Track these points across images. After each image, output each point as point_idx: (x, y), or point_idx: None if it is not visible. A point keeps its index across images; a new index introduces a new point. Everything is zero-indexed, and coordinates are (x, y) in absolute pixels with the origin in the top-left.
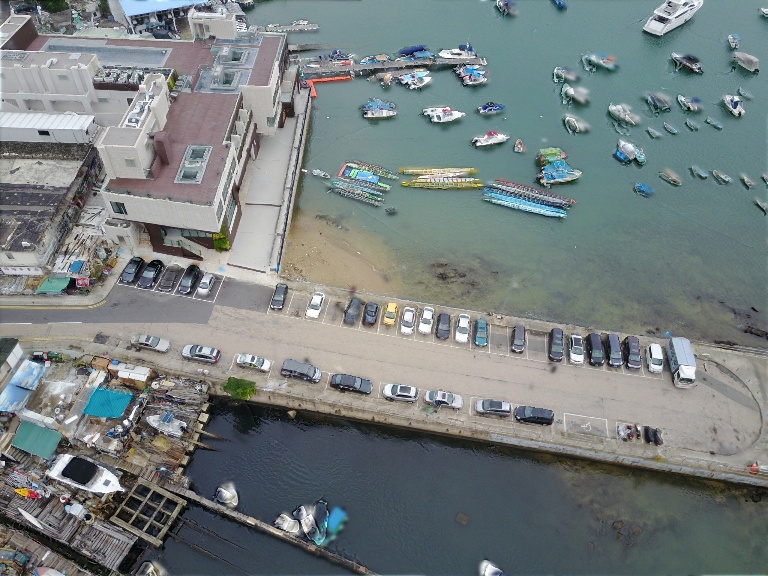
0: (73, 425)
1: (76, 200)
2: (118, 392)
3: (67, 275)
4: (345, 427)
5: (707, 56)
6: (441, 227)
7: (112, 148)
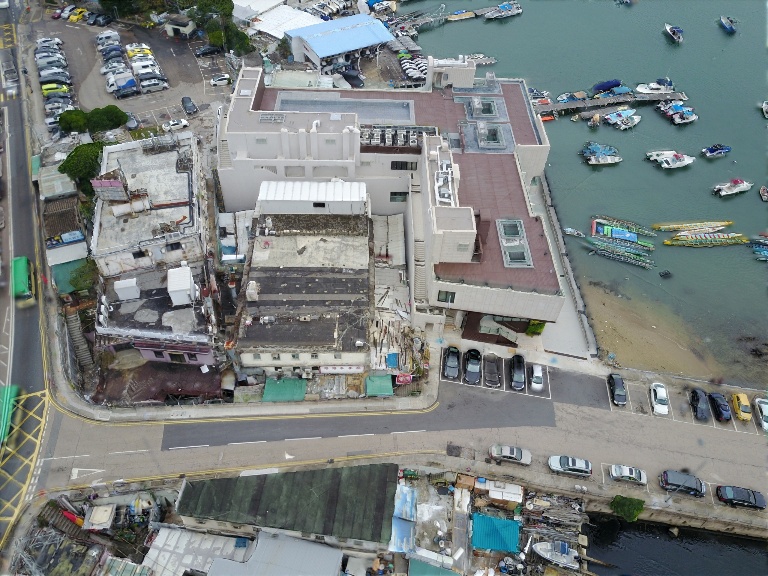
0: (462, 560)
1: None
2: (494, 516)
3: (388, 372)
4: (734, 545)
5: None
6: (726, 293)
7: (450, 233)
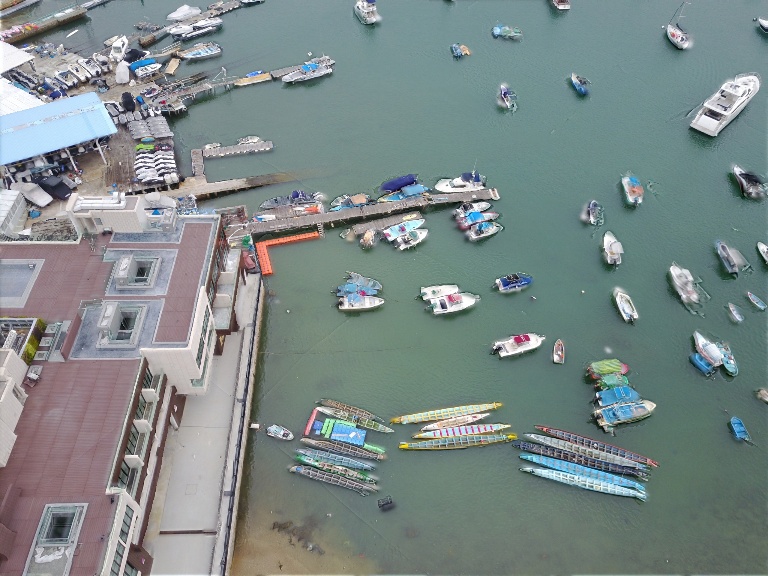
0: None
1: None
2: None
3: None
4: None
5: None
6: (463, 533)
7: None
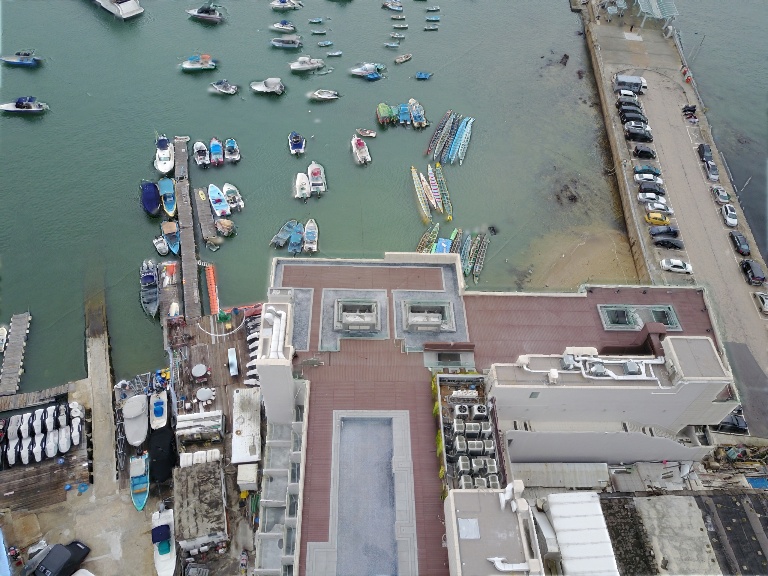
0: None
1: None
2: None
3: None
4: None
5: (173, 1)
6: (506, 197)
7: None
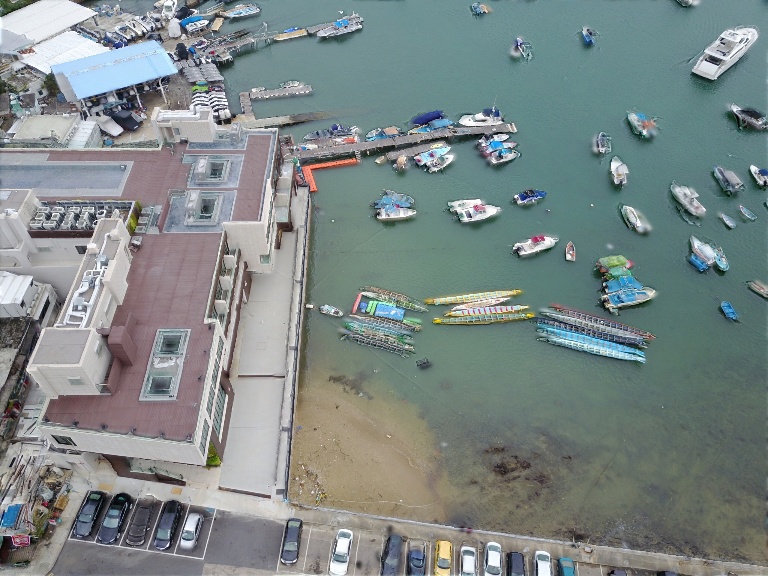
0: None
1: (10, 409)
2: None
3: None
4: None
5: None
6: (489, 386)
7: (48, 368)
